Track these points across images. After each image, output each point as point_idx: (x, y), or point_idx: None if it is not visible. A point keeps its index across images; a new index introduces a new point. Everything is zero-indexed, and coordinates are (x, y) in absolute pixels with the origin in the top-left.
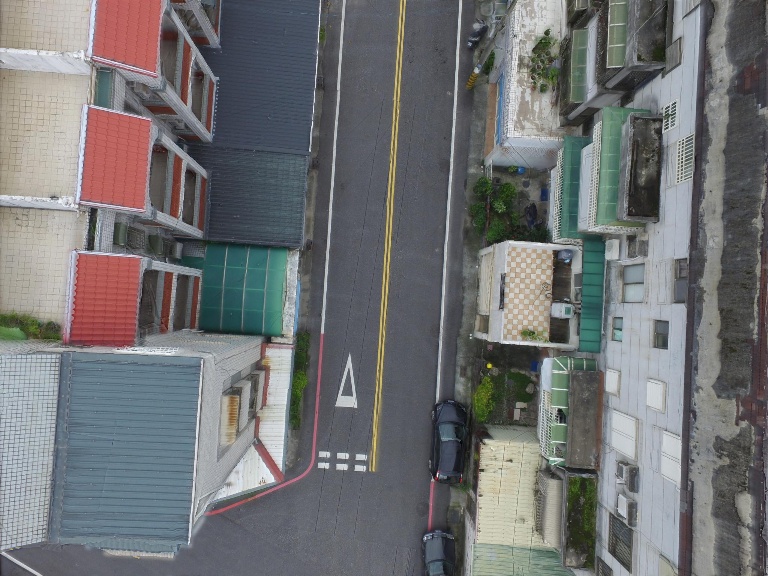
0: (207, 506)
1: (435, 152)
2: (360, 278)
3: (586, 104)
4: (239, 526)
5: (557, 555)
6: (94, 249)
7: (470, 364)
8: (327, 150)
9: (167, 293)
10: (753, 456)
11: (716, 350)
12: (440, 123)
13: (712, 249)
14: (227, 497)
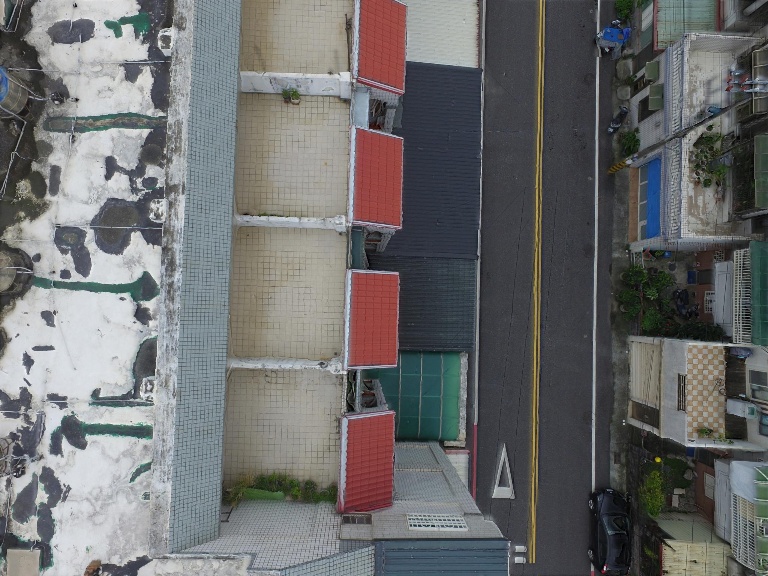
0: None
1: (579, 238)
2: (510, 367)
3: None
4: None
5: None
6: (354, 409)
7: (624, 450)
8: None
9: None
10: None
11: None
12: (583, 209)
13: None
14: None
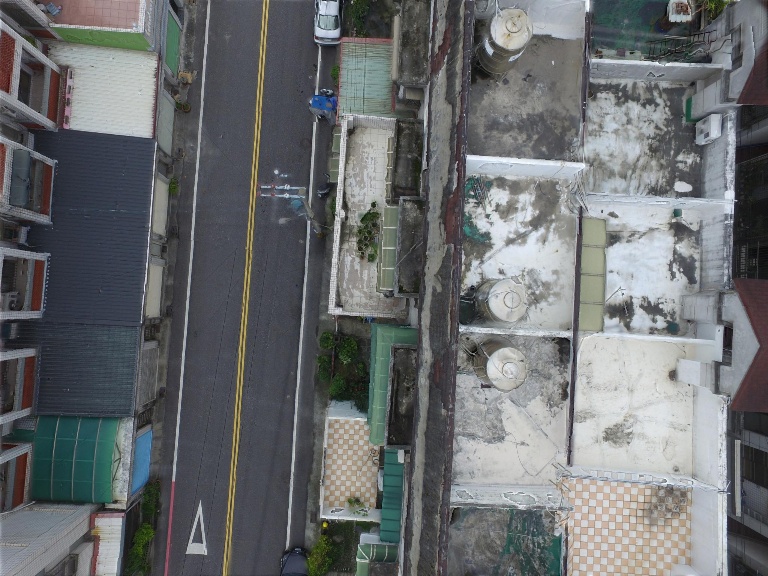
0: None
1: (287, 300)
2: (212, 425)
3: None
4: None
5: None
6: None
7: None
8: (181, 298)
9: None
10: None
11: None
12: (292, 271)
13: (416, 526)
14: None
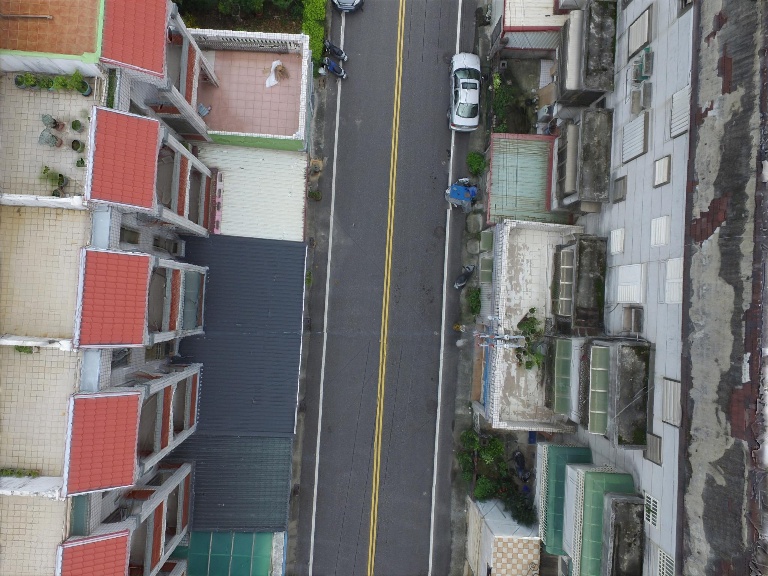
0: None
1: (422, 394)
2: (348, 524)
3: None
4: None
5: None
6: None
7: None
8: (314, 392)
9: None
10: None
11: None
12: (427, 364)
13: None
14: None
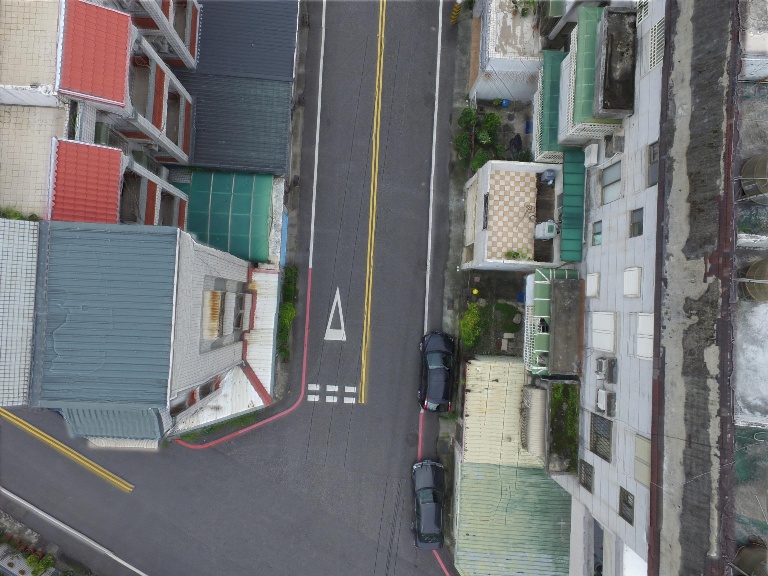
0: (198, 436)
1: (420, 87)
2: (347, 212)
3: (565, 17)
4: (230, 458)
5: (543, 472)
6: None
7: (457, 296)
8: (313, 87)
9: (151, 203)
10: (721, 308)
11: (685, 214)
12: (425, 58)
13: (681, 117)
14: (216, 420)
